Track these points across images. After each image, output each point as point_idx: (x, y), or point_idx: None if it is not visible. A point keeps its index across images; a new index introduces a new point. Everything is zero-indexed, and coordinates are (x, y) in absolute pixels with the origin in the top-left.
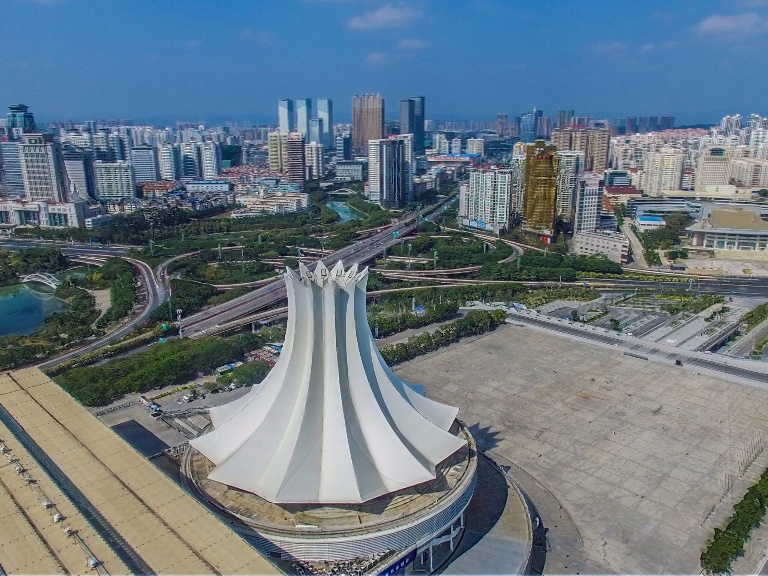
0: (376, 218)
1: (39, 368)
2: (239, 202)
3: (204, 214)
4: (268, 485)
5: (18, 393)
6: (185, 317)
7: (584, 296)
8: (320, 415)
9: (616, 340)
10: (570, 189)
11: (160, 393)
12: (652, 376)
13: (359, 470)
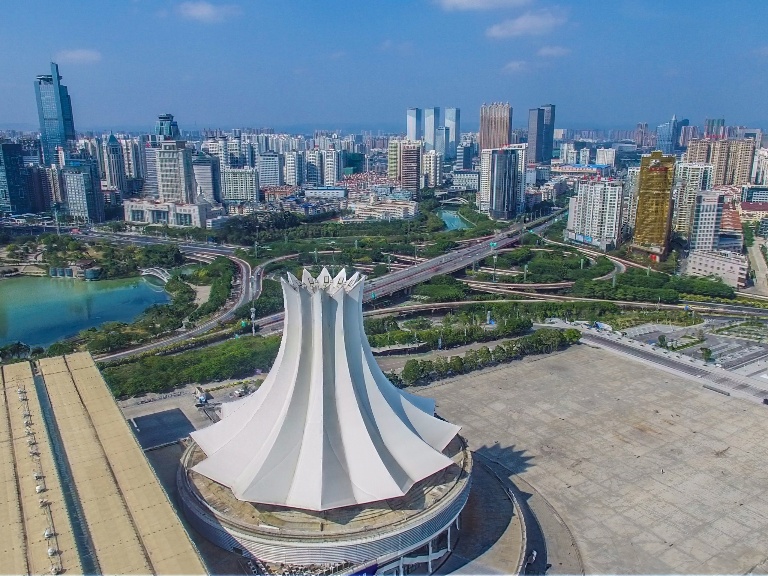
0: (481, 228)
1: (129, 354)
2: (350, 208)
3: (315, 219)
4: (242, 482)
5: (63, 374)
6: (267, 316)
7: (682, 320)
8: (303, 419)
9: (701, 371)
10: (688, 204)
11: (217, 386)
12: (728, 414)
13: (329, 478)
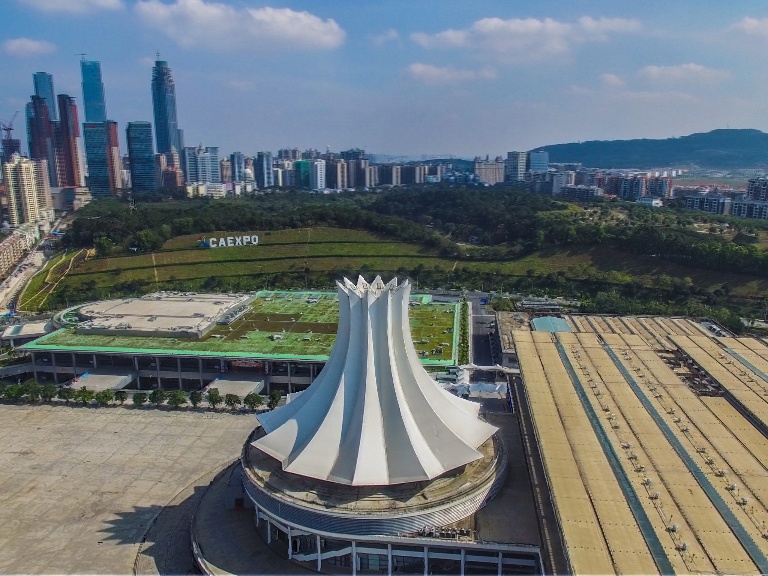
0: None
1: None
2: None
3: None
4: None
5: None
6: None
7: None
8: None
9: None
10: None
11: None
12: None
13: None
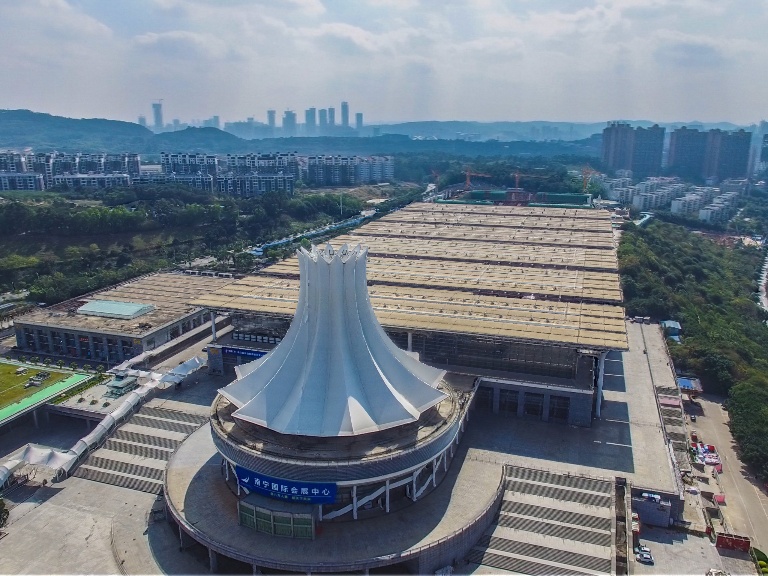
0: None
1: None
2: None
3: None
4: None
5: None
6: None
7: None
8: None
9: None
10: None
11: None
12: None
13: None
